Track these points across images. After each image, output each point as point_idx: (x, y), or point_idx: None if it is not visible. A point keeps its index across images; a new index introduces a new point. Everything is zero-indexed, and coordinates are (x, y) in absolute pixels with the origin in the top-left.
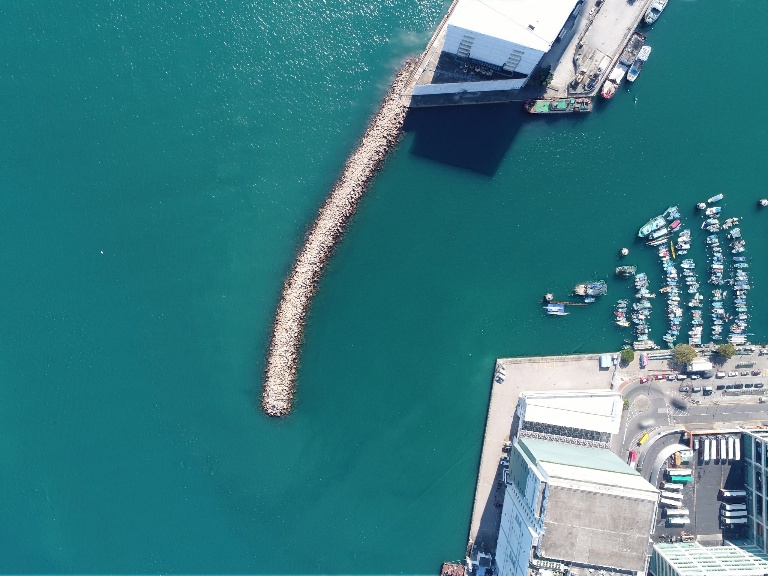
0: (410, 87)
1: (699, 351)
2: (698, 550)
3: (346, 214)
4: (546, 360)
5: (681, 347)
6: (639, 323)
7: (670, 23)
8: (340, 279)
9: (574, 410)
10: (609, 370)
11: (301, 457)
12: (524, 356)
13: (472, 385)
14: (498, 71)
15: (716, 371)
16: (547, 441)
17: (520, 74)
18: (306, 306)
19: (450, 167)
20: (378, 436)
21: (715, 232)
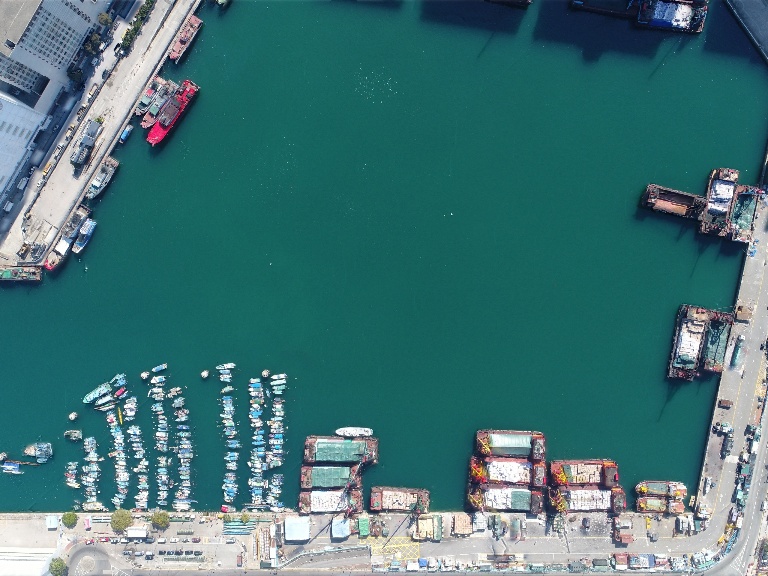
0: None
1: (141, 516)
2: None
3: None
4: None
5: (117, 513)
6: (88, 485)
7: (117, 196)
8: None
9: None
10: (57, 530)
11: None
12: None
13: None
14: None
15: (158, 536)
16: None
17: None
18: None
19: None
20: None
21: (160, 400)
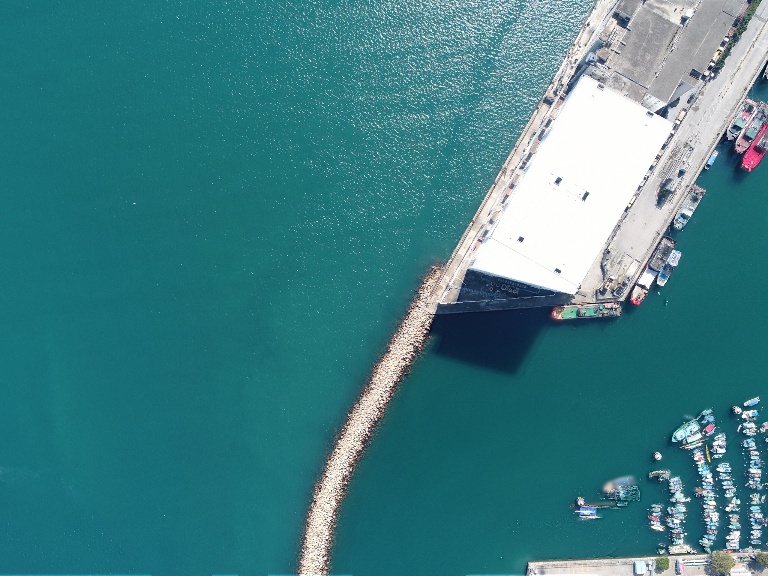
0: (436, 294)
1: (737, 557)
2: None
3: (374, 419)
4: (579, 565)
5: (718, 556)
6: (674, 527)
7: (701, 225)
8: (370, 481)
9: None
10: (644, 575)
11: None
12: (556, 559)
13: None
14: (524, 288)
15: None
16: None
17: (547, 290)
18: (336, 508)
19: (478, 373)
20: None
21: (752, 436)
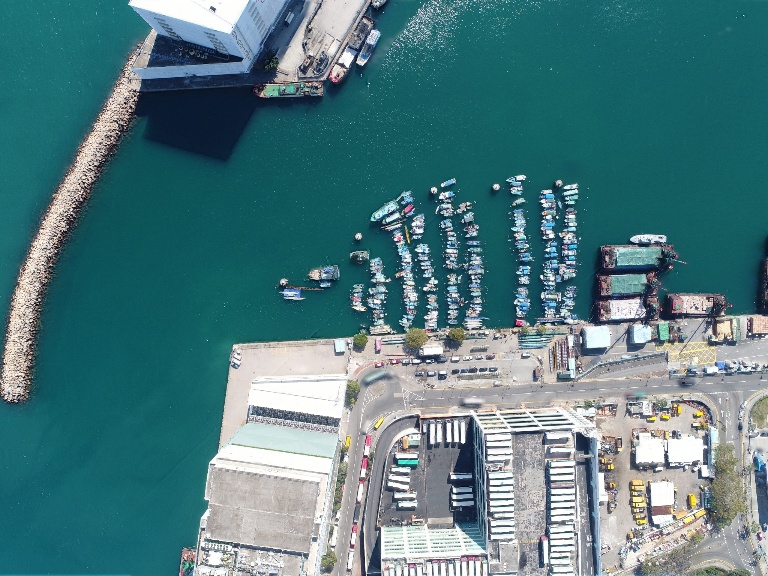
0: None
1: (433, 335)
2: (420, 533)
3: (79, 199)
4: (282, 345)
5: (412, 331)
6: (375, 308)
7: (401, 7)
8: (78, 265)
9: (297, 394)
10: (344, 355)
11: (40, 444)
12: (262, 341)
13: (211, 370)
14: (214, 54)
15: (451, 355)
16: (275, 426)
17: (237, 57)
18: (42, 292)
19: (181, 152)
20: (117, 422)
21: (449, 216)
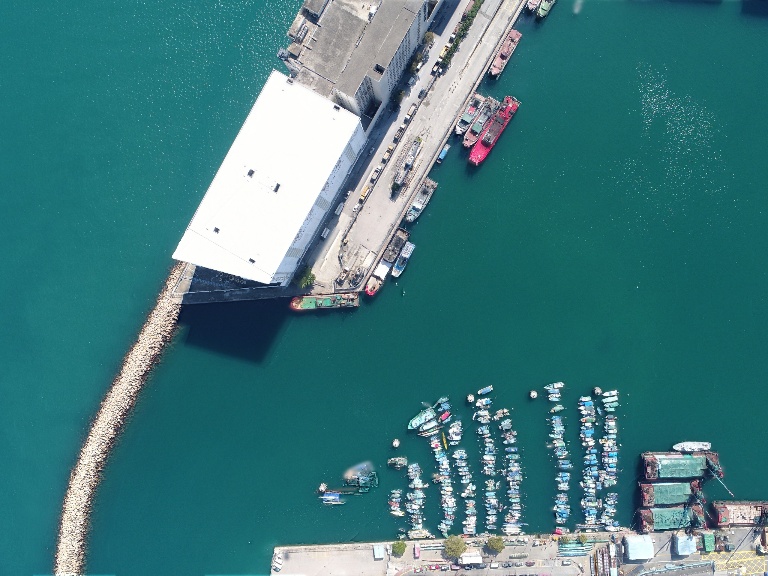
0: None
1: (472, 542)
2: None
3: (126, 407)
4: (322, 549)
5: (450, 540)
6: (413, 513)
7: (435, 217)
8: (125, 467)
9: None
10: (383, 560)
11: None
12: (302, 544)
13: (253, 571)
14: None
15: (490, 561)
16: None
17: None
18: (92, 494)
19: (222, 362)
20: None
21: (486, 423)
